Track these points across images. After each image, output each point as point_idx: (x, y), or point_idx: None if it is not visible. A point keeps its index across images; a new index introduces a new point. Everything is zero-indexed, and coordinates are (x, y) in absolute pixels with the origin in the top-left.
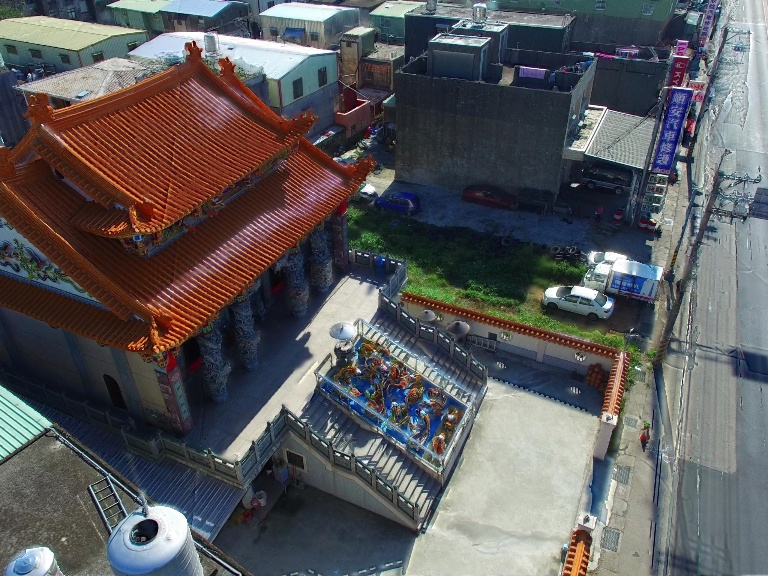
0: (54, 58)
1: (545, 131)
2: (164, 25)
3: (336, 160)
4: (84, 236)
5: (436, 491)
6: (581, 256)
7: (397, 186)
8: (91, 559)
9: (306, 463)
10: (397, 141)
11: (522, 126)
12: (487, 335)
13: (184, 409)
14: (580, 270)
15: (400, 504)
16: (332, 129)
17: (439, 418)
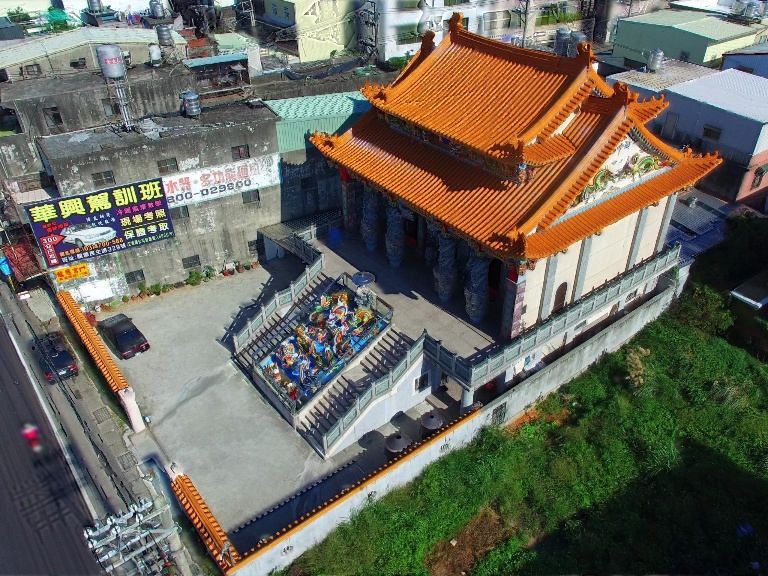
0: None
1: None
2: None
3: None
4: None
5: None
6: None
7: None
8: (201, 122)
9: None
10: None
11: None
12: None
13: None
14: None
15: (247, 334)
16: None
17: None
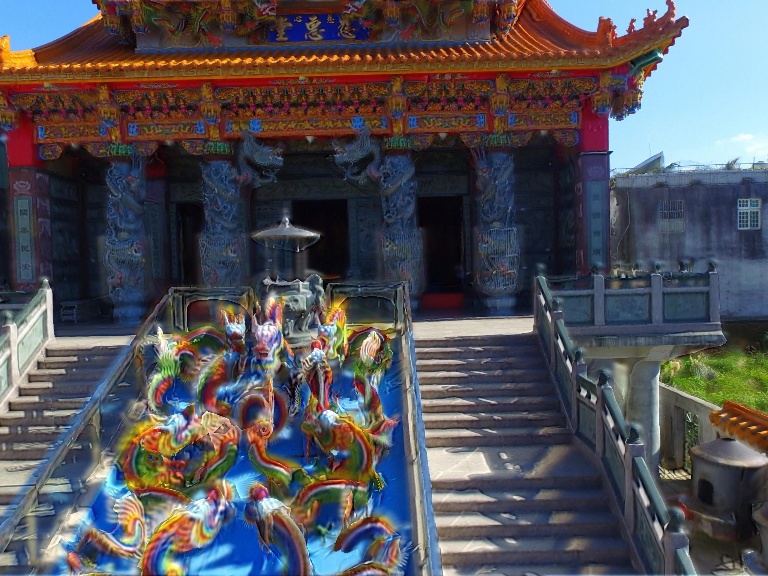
0: None
1: None
2: None
3: None
4: None
5: None
6: None
7: None
8: None
9: None
10: None
11: None
12: None
13: (28, 261)
14: None
15: None
16: None
17: None
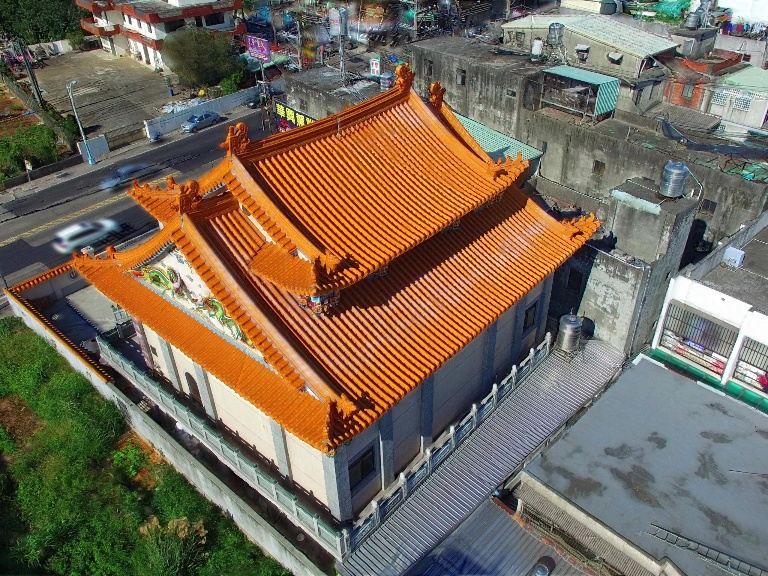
0: None
1: None
2: None
3: None
4: None
5: None
6: None
7: None
8: None
9: None
10: None
11: None
12: None
13: None
14: None
15: None
16: None
17: None
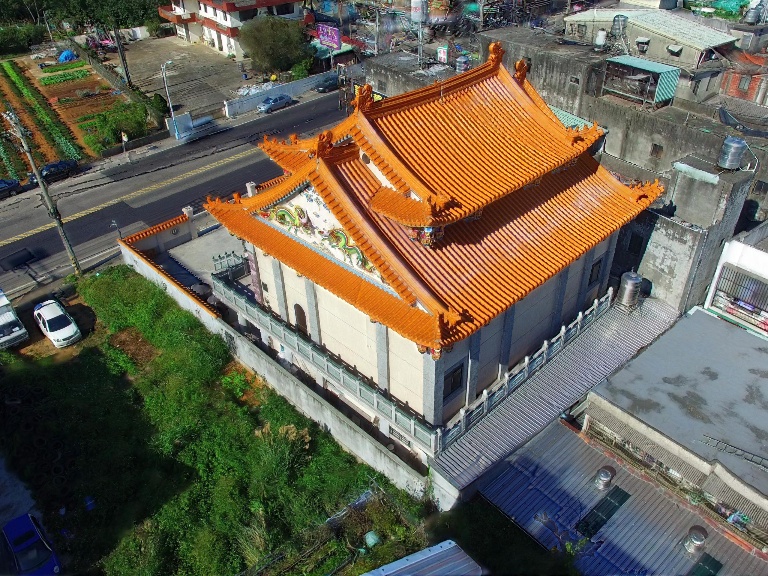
0: None
1: None
2: None
3: None
4: None
5: None
6: None
7: None
8: None
9: None
10: None
11: None
12: None
13: None
14: (1, 352)
15: None
16: None
17: None
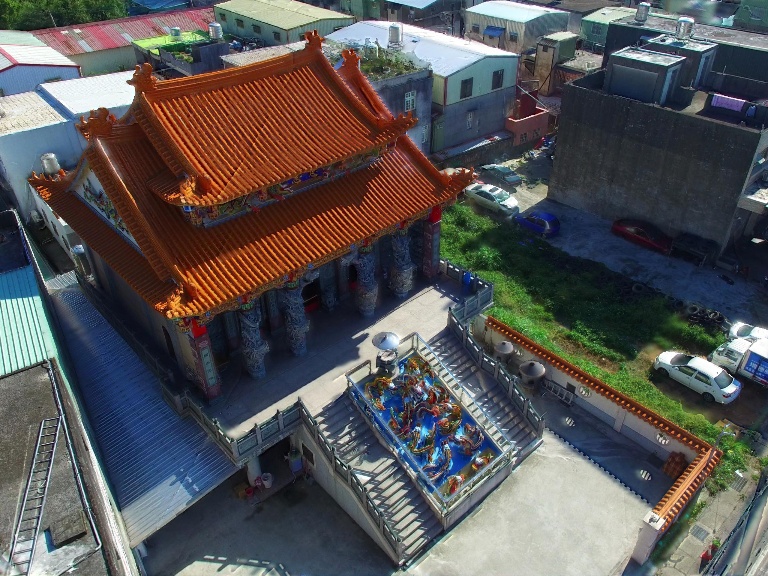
0: (269, 34)
1: (721, 172)
2: (380, 13)
3: (492, 166)
4: (155, 198)
5: (435, 532)
6: (723, 324)
7: (546, 204)
8: (6, 484)
9: (315, 460)
10: (555, 157)
11: (695, 162)
12: (565, 385)
13: (211, 375)
14: (716, 340)
15: (386, 532)
16: (499, 134)
17: (468, 457)
